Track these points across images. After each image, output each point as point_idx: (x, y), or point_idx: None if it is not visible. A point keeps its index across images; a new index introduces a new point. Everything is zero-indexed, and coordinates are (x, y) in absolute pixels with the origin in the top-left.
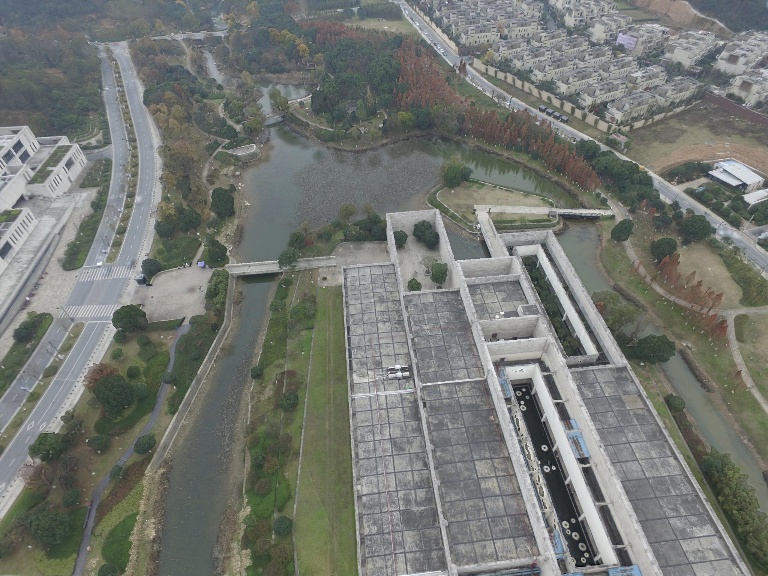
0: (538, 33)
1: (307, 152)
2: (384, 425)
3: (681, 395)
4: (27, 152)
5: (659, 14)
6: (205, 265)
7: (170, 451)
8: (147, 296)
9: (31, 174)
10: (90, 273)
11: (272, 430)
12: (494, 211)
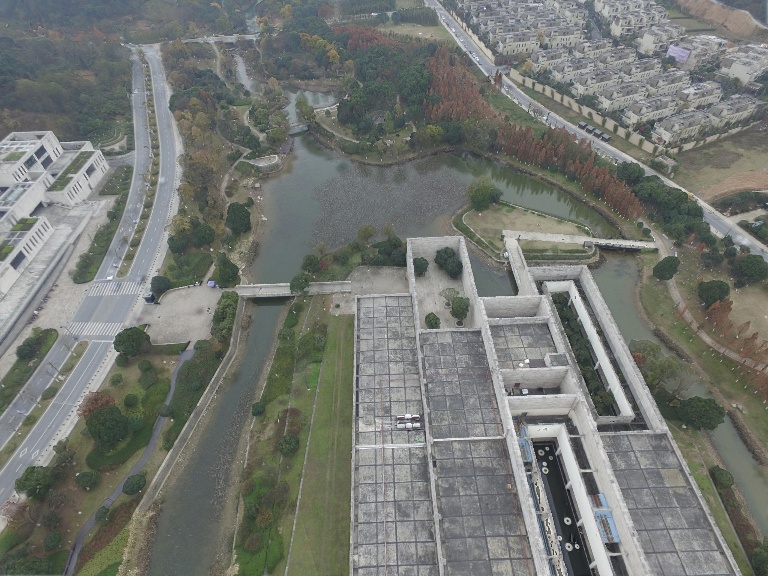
0: (581, 43)
1: (330, 165)
2: (389, 484)
3: (729, 467)
4: (50, 157)
5: (715, 24)
6: (216, 284)
7: (161, 491)
8: (154, 315)
9: (51, 181)
10: (100, 287)
11: (269, 477)
12: (524, 238)
